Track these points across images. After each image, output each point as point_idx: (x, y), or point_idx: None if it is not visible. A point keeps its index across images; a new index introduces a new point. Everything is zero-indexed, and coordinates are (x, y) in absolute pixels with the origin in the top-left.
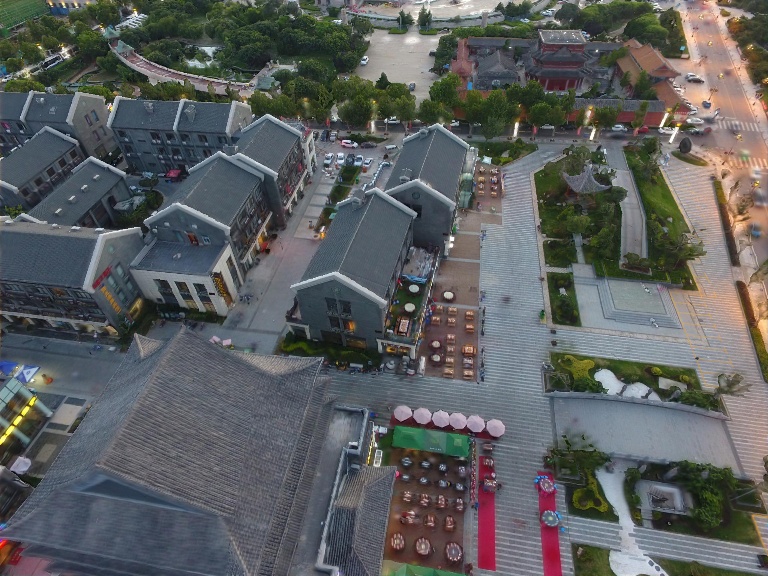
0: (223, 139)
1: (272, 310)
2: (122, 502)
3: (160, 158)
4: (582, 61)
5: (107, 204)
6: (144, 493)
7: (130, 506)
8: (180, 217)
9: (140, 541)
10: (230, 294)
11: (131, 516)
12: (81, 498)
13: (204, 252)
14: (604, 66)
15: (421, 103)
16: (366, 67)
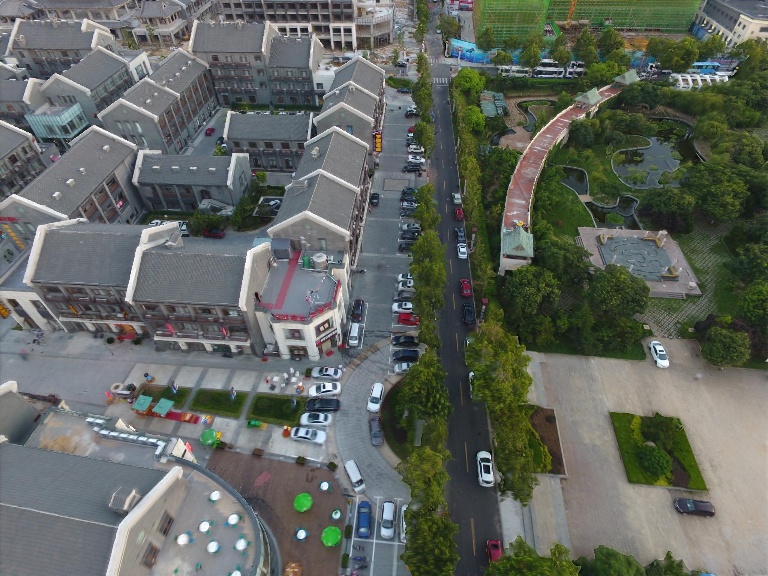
0: None
1: (8, 368)
2: None
3: None
4: None
5: (199, 193)
6: None
7: None
8: None
9: None
10: (36, 322)
11: None
12: None
13: None
14: None
15: (447, 514)
16: (764, 387)
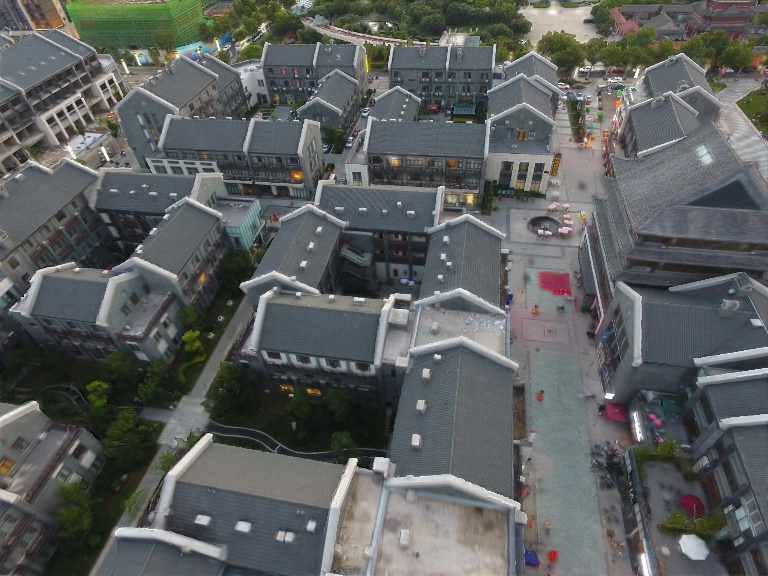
0: (485, 75)
1: (579, 190)
2: (711, 211)
3: (422, 95)
4: (749, 17)
5: None
6: (748, 193)
7: (716, 213)
8: (521, 115)
9: (728, 231)
10: None
11: (718, 218)
12: (681, 211)
13: (532, 144)
14: (756, 24)
15: None
16: (532, 33)
